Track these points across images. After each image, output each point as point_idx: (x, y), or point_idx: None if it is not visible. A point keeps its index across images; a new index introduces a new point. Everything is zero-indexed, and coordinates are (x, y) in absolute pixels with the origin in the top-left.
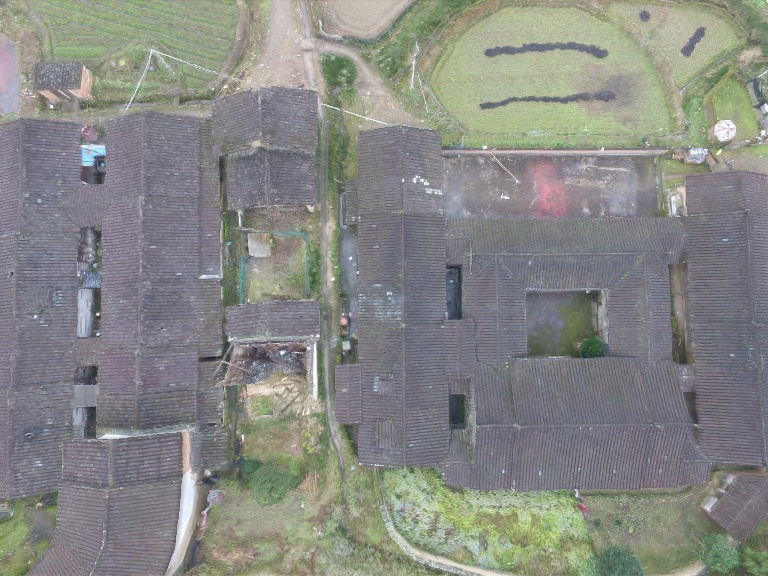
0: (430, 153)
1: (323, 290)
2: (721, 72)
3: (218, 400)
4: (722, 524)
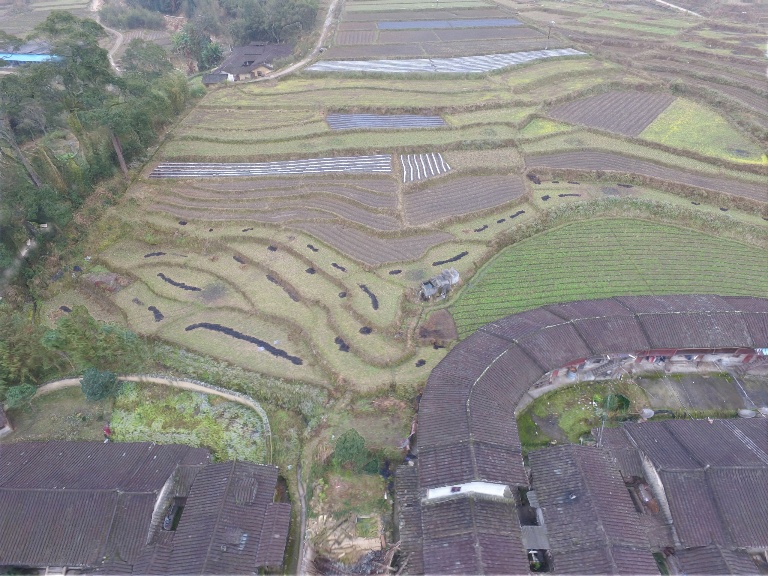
0: None
1: None
2: None
3: (404, 530)
4: (3, 415)
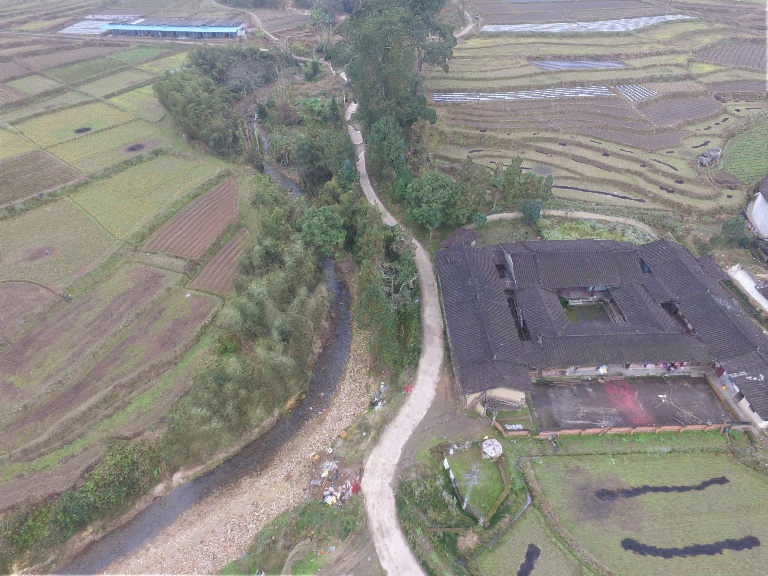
0: (763, 401)
1: (766, 327)
2: (497, 519)
3: None
4: (474, 231)
